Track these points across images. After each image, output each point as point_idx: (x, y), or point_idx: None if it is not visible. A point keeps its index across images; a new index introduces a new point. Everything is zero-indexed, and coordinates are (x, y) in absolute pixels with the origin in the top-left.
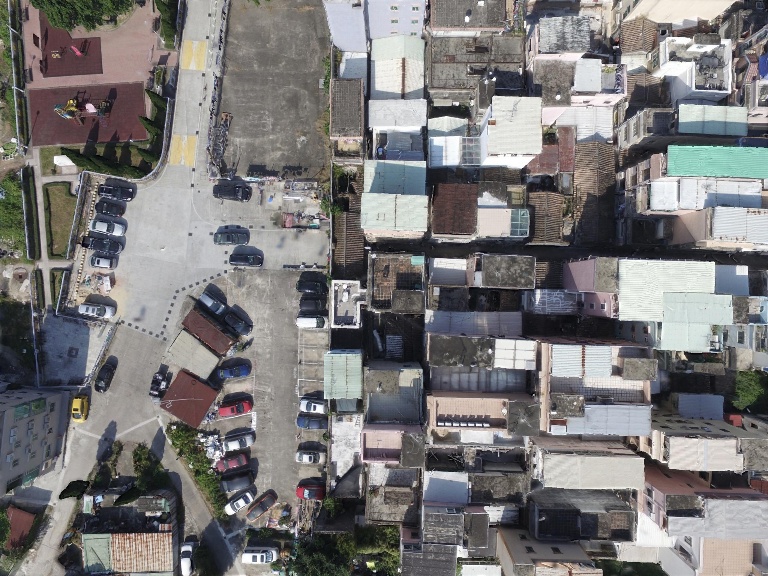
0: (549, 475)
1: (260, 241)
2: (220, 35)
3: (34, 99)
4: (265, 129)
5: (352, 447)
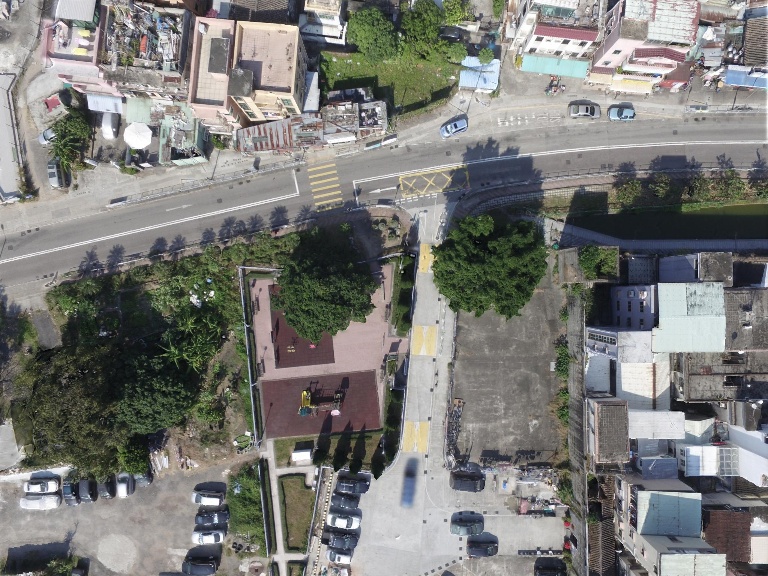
0: None
1: (494, 527)
2: None
3: (267, 391)
4: (497, 414)
5: None
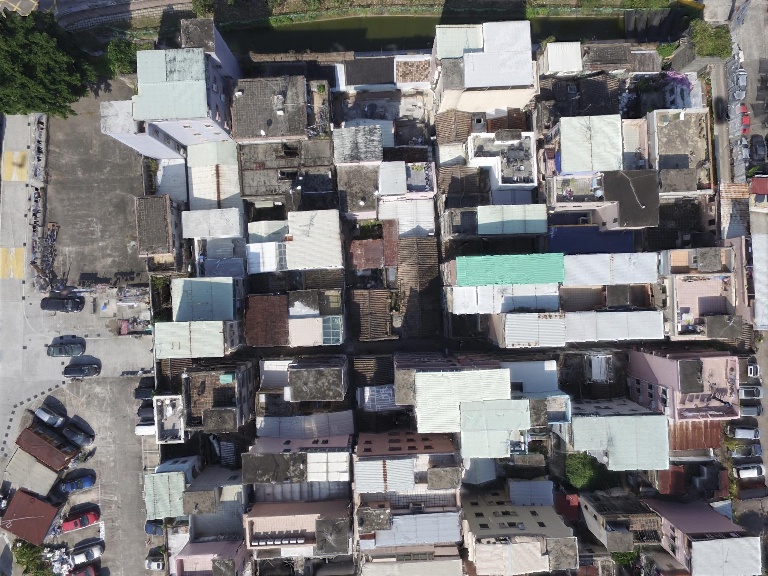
0: None
1: (97, 349)
2: (38, 146)
3: None
4: (94, 236)
5: None
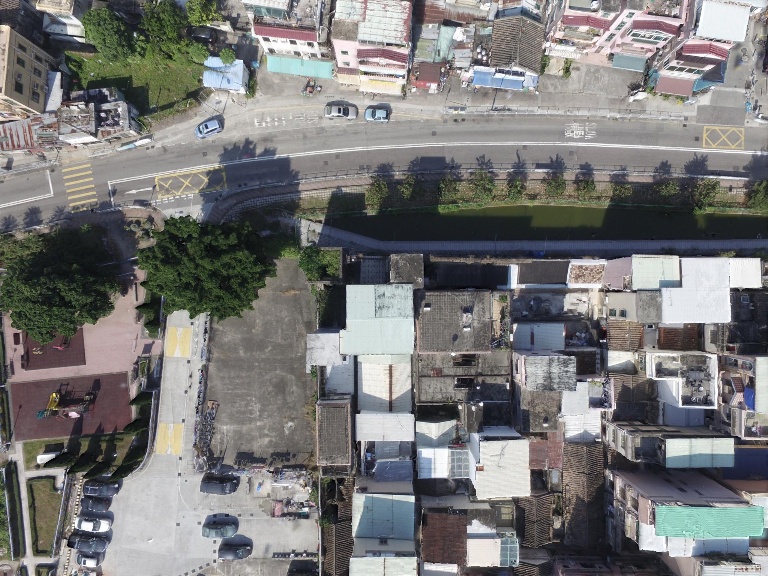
0: None
1: (249, 529)
2: (205, 328)
3: (16, 393)
4: (252, 416)
5: None
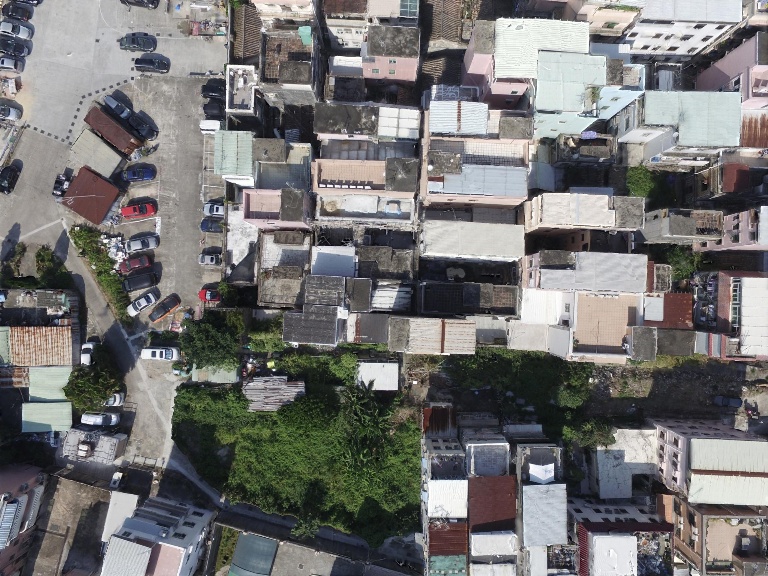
0: (430, 240)
1: (167, 49)
2: None
3: None
4: None
5: (248, 236)
